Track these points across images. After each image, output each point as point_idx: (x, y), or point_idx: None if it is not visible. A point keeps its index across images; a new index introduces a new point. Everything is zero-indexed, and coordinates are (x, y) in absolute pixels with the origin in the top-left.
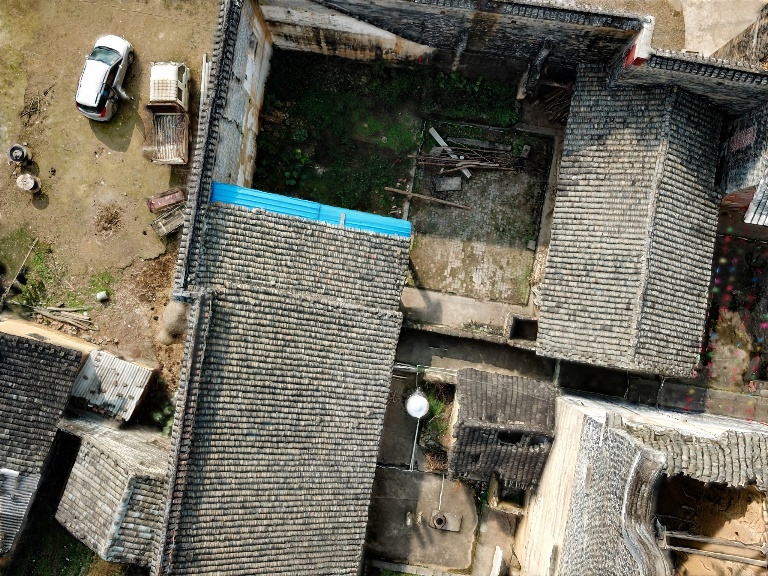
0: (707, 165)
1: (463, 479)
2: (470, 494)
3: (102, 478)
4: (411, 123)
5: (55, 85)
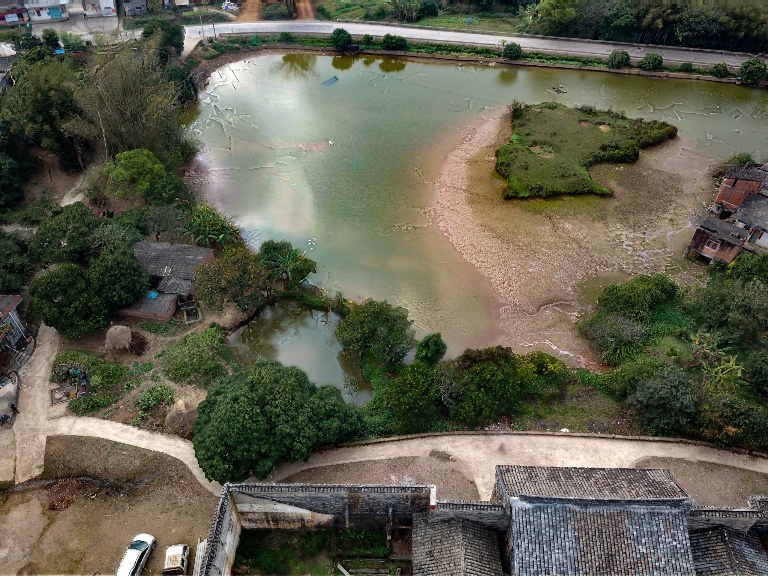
0: (494, 561)
1: None
2: None
3: None
4: (326, 563)
5: (102, 569)
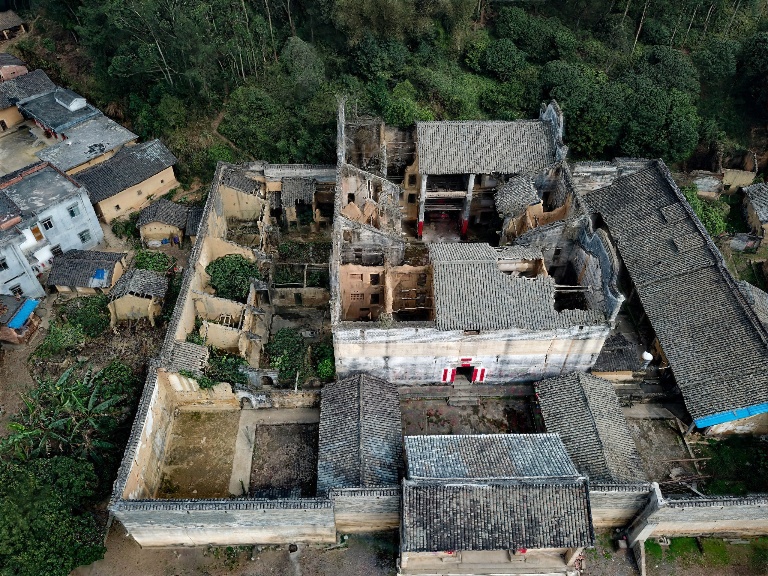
0: None
1: None
2: None
3: (764, 305)
4: None
5: None
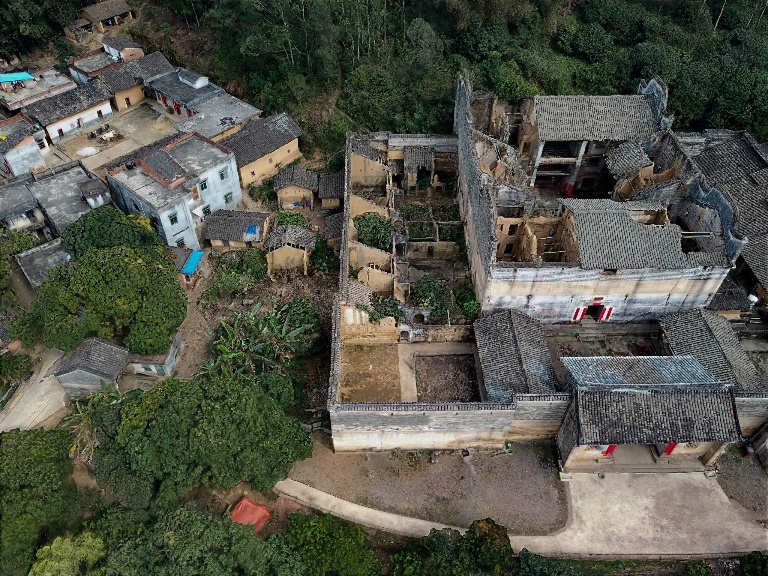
0: None
1: None
2: None
3: None
4: None
5: None
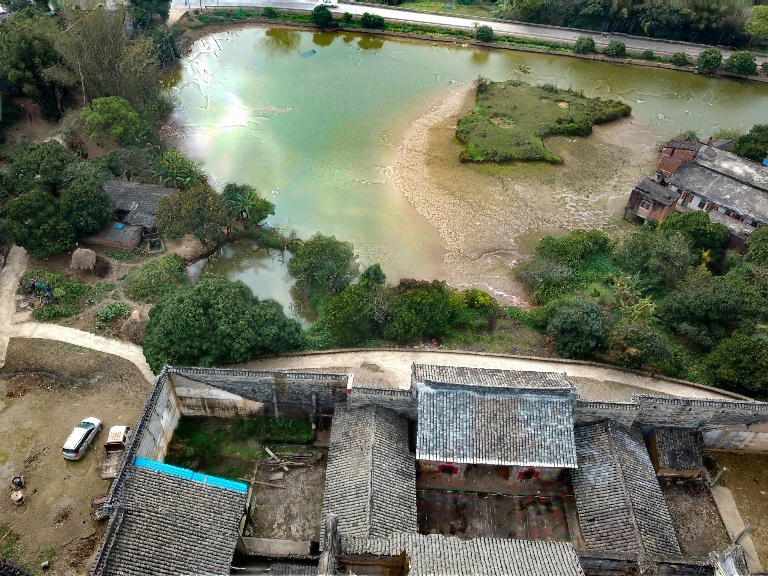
0: (402, 441)
1: None
2: None
3: None
4: (255, 446)
5: (51, 445)
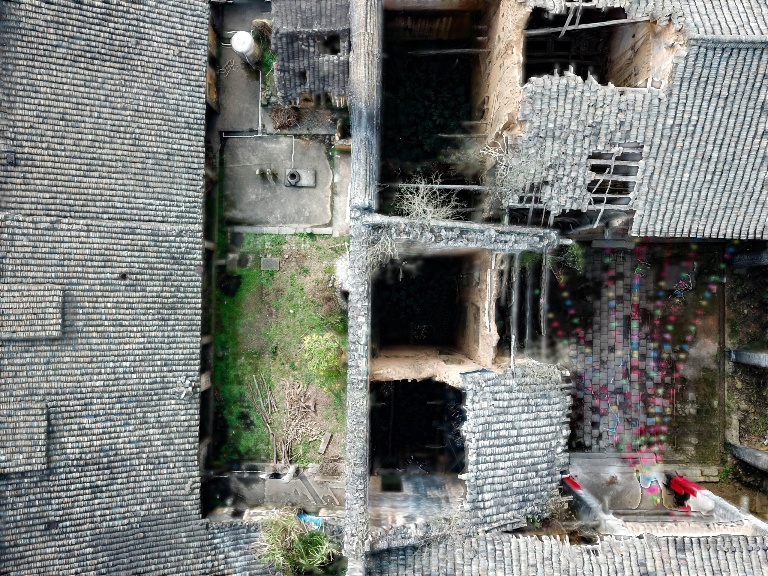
0: None
1: (312, 137)
2: (321, 151)
3: None
4: None
5: None
